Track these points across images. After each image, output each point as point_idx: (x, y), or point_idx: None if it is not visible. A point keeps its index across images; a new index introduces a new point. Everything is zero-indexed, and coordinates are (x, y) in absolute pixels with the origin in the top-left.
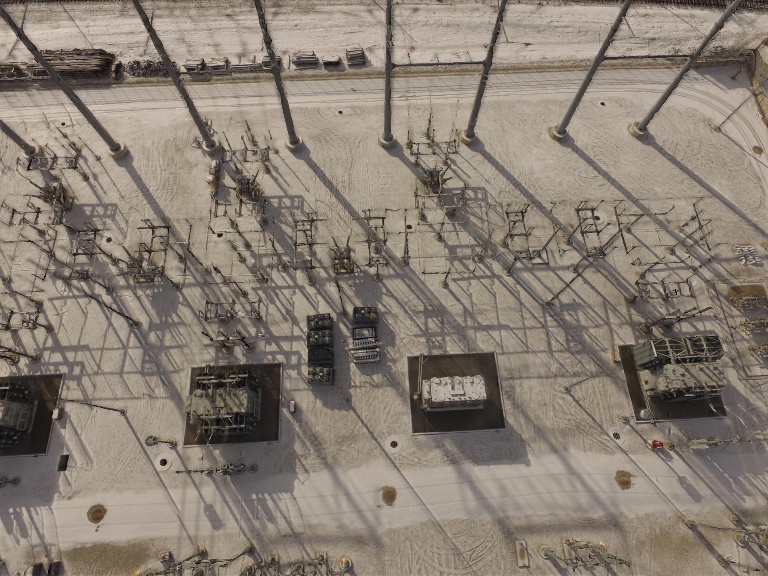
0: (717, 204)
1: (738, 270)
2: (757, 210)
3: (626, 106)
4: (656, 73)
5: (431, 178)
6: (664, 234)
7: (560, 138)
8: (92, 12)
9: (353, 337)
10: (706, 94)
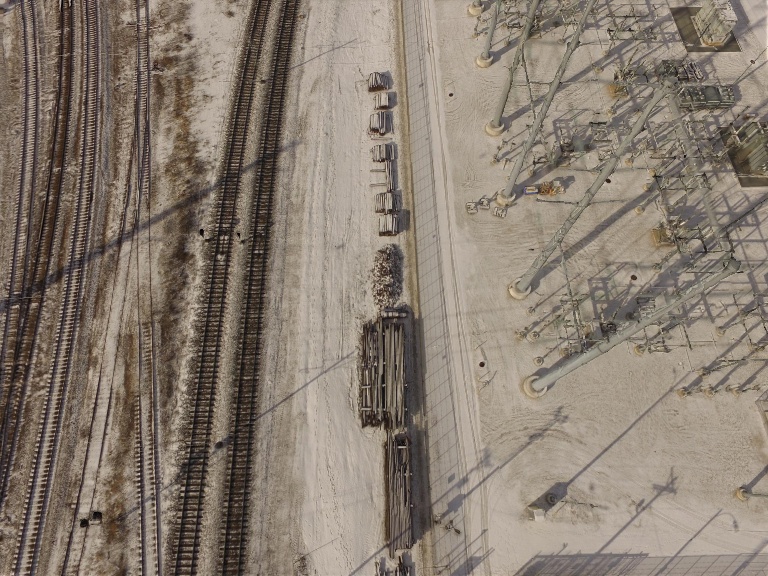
0: None
1: None
2: None
3: None
4: None
5: (537, 22)
6: None
7: None
8: (278, 370)
9: (686, 79)
10: None
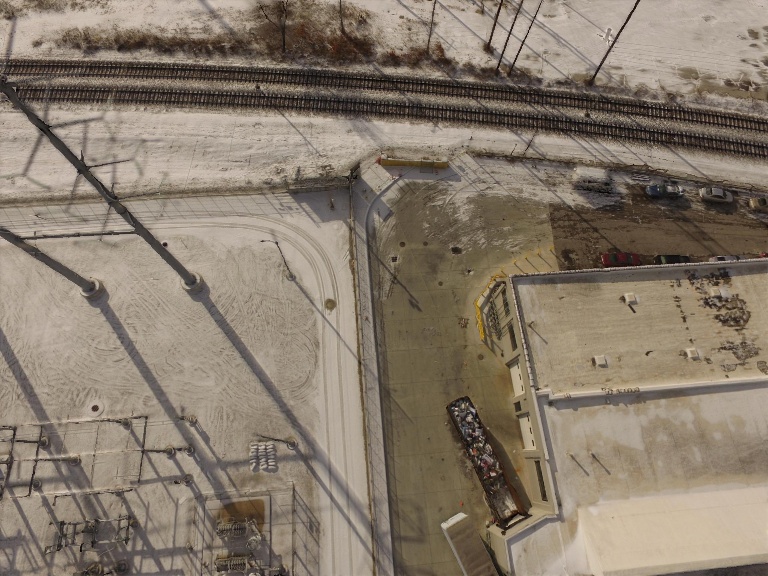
0: (252, 383)
1: (244, 478)
2: (299, 390)
3: (192, 247)
4: (244, 201)
5: None
6: (171, 428)
7: (87, 296)
8: None
9: None
10: (294, 229)
